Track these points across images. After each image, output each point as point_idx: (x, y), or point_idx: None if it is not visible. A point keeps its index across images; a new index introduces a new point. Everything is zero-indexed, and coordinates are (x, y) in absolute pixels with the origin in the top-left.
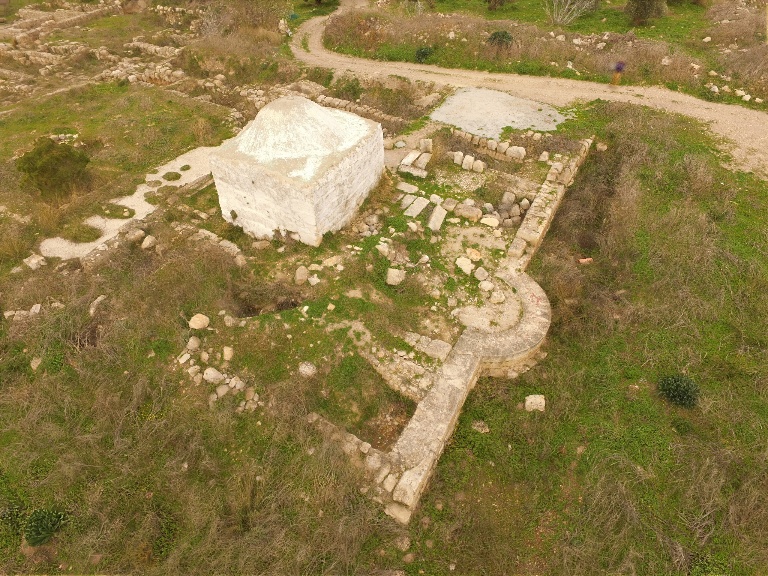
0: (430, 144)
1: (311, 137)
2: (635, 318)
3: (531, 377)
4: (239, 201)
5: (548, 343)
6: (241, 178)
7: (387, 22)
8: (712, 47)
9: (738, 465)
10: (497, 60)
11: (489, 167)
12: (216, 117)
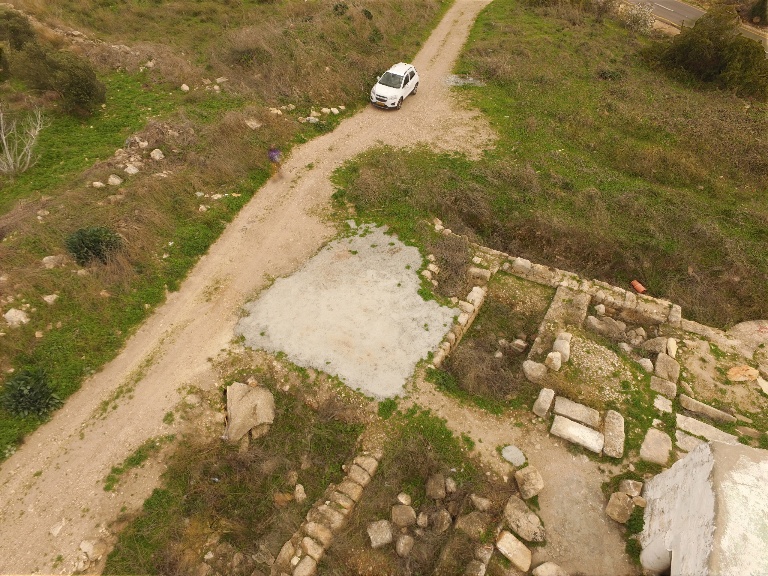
0: None
1: None
2: None
3: None
4: None
5: None
6: None
7: None
8: None
9: None
10: (147, 269)
11: None
12: None
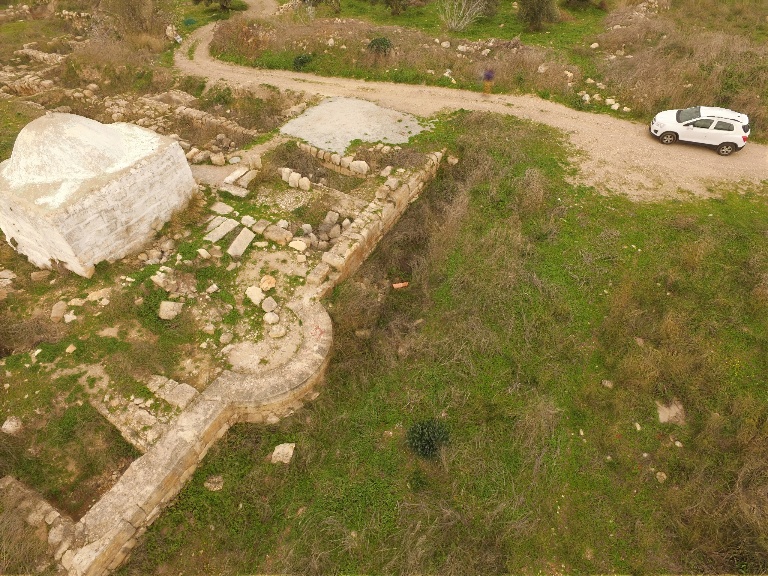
0: (257, 160)
1: (70, 159)
2: (412, 353)
3: (289, 422)
4: (12, 228)
5: (324, 381)
6: (2, 204)
7: (270, 28)
8: (599, 53)
9: (464, 526)
10: (375, 68)
11: None
12: None
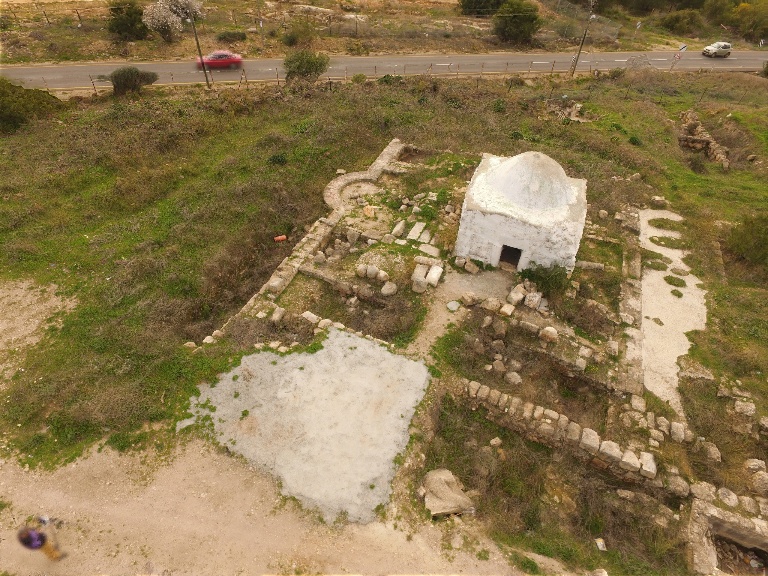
0: None
1: None
2: None
3: None
4: None
5: None
6: None
7: None
8: None
9: None
10: None
11: None
12: (763, 392)
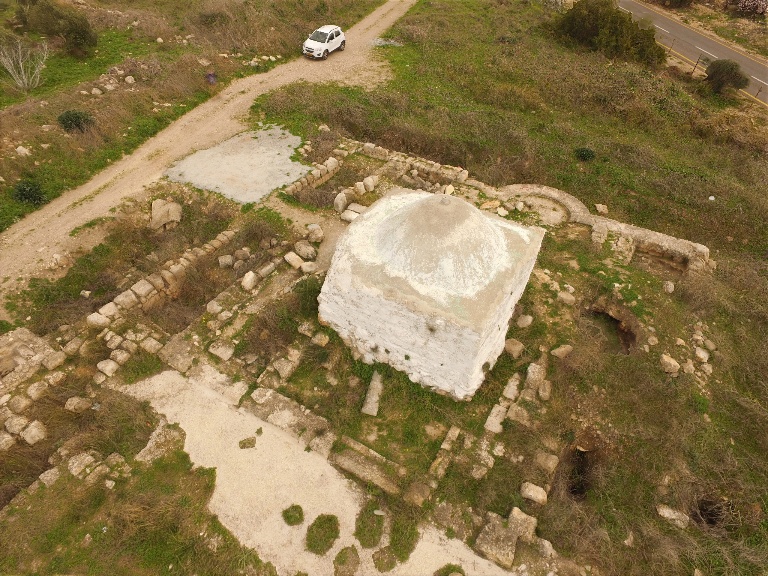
0: (345, 197)
1: None
2: None
3: None
4: None
5: None
6: None
7: None
8: None
9: None
10: (111, 140)
11: None
12: (79, 503)
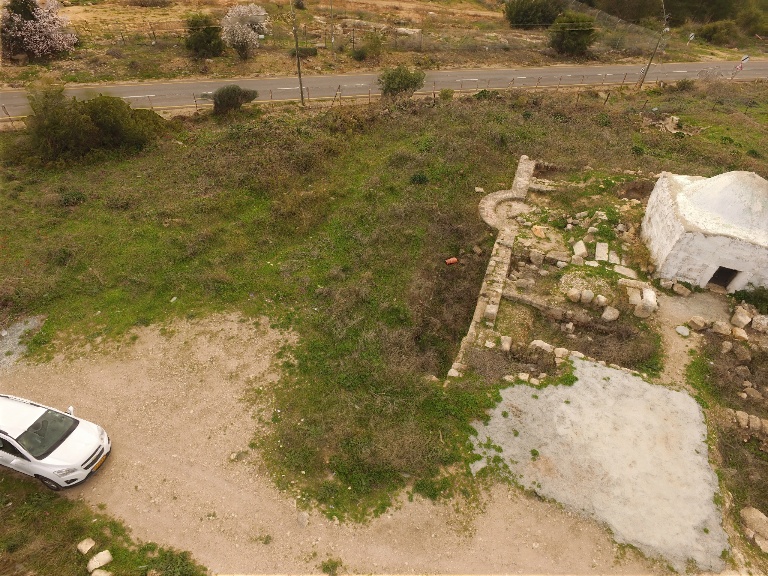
0: None
1: None
2: None
3: None
4: None
5: None
6: None
7: None
8: None
9: None
10: None
11: (564, 342)
12: None
